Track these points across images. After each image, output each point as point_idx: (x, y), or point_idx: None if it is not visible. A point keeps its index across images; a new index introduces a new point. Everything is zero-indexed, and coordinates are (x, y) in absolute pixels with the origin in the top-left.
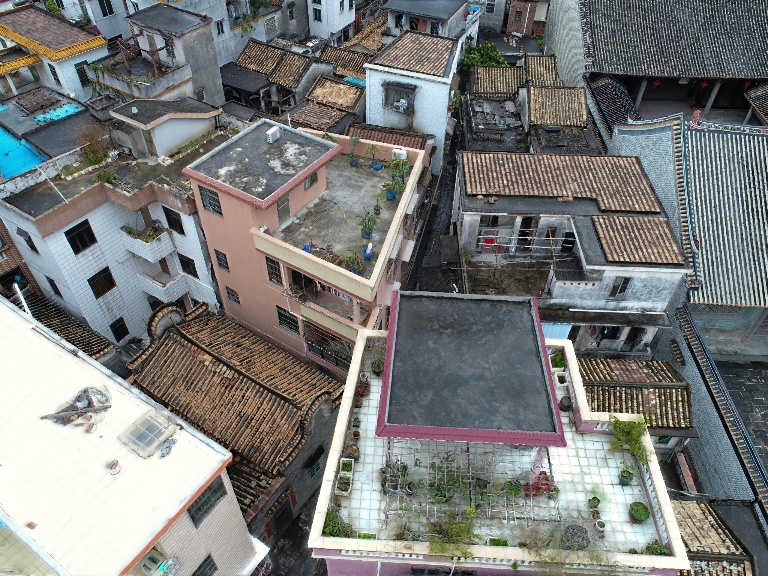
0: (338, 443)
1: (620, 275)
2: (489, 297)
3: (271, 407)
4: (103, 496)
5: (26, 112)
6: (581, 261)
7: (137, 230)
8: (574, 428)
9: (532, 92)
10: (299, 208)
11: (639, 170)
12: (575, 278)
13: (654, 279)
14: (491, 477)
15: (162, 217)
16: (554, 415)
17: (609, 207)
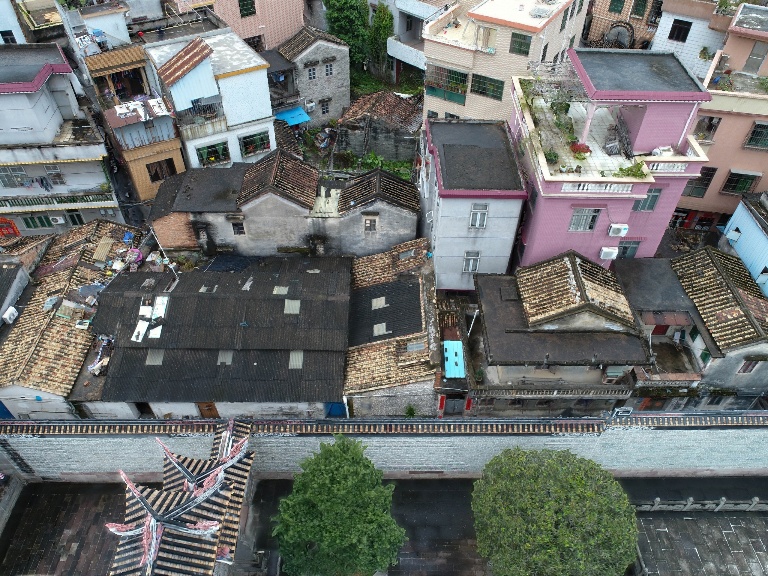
0: None
1: None
2: None
3: None
4: None
5: None
6: None
7: (708, 53)
8: None
9: None
10: None
11: None
12: None
13: None
14: None
15: None
16: None
17: None
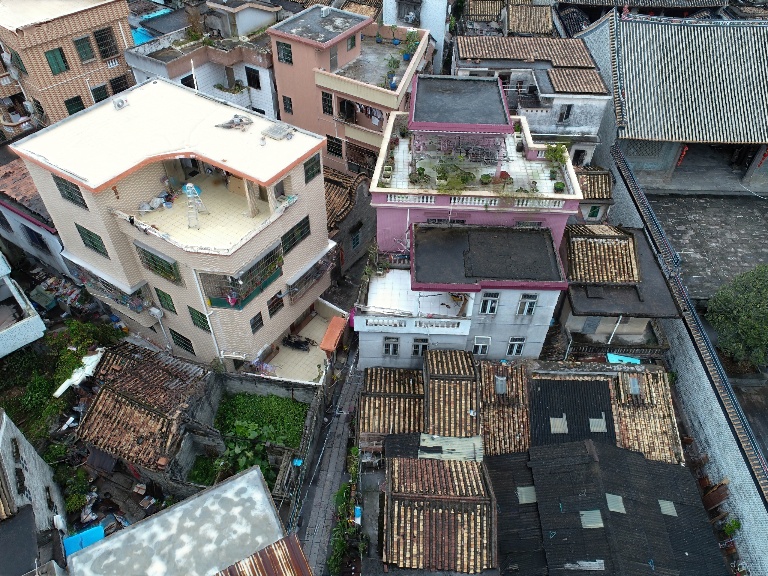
0: (382, 155)
1: (564, 103)
2: (472, 78)
3: (328, 190)
4: (259, 152)
5: (134, 13)
6: (539, 97)
7: None
8: (525, 158)
9: (510, 9)
10: (343, 64)
11: (583, 45)
12: (534, 106)
13: (588, 106)
14: (472, 147)
15: (244, 77)
16: (508, 119)
17: (559, 64)
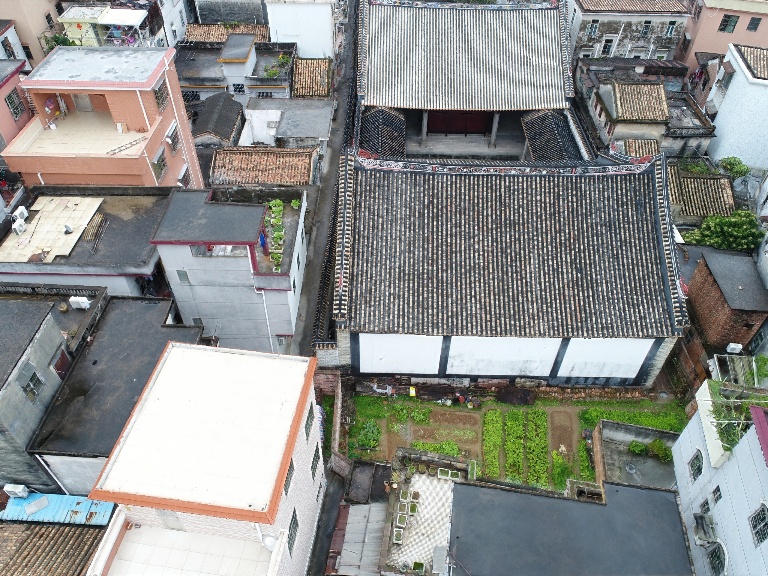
0: None
1: None
2: None
3: None
4: None
5: None
6: None
7: None
8: None
9: None
10: None
11: (583, 4)
12: None
13: None
14: None
15: None
16: None
17: None
